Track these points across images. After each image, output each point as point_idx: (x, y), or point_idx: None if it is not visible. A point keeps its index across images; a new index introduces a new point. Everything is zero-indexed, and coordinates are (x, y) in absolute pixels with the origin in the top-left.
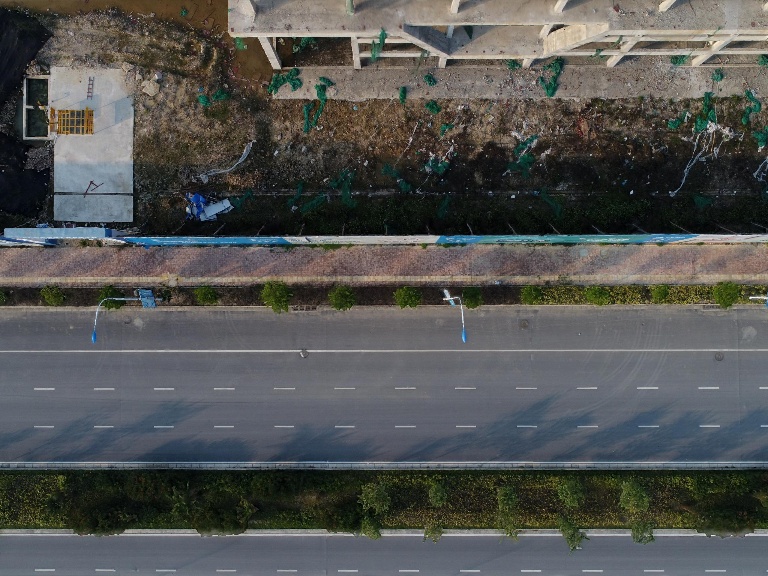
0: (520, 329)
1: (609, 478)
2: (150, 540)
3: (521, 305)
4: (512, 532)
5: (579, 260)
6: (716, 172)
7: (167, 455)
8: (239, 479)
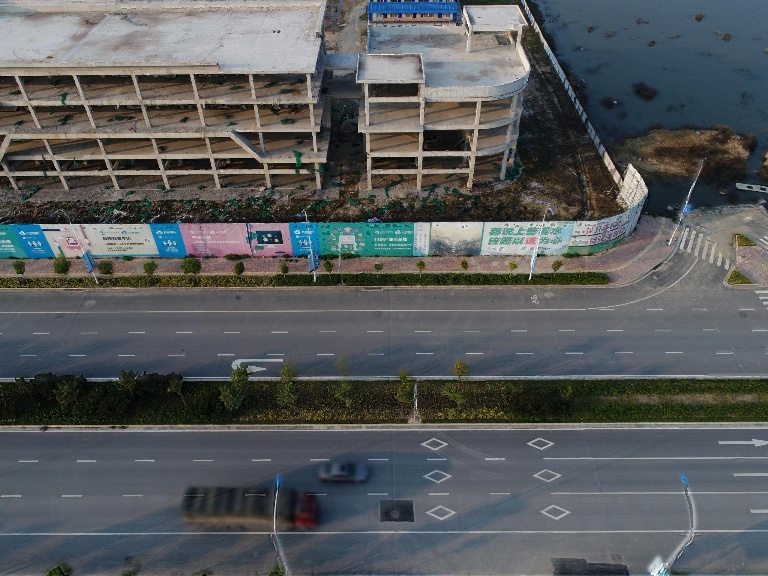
0: None
1: None
2: None
3: None
4: None
5: None
6: None
7: None
8: None
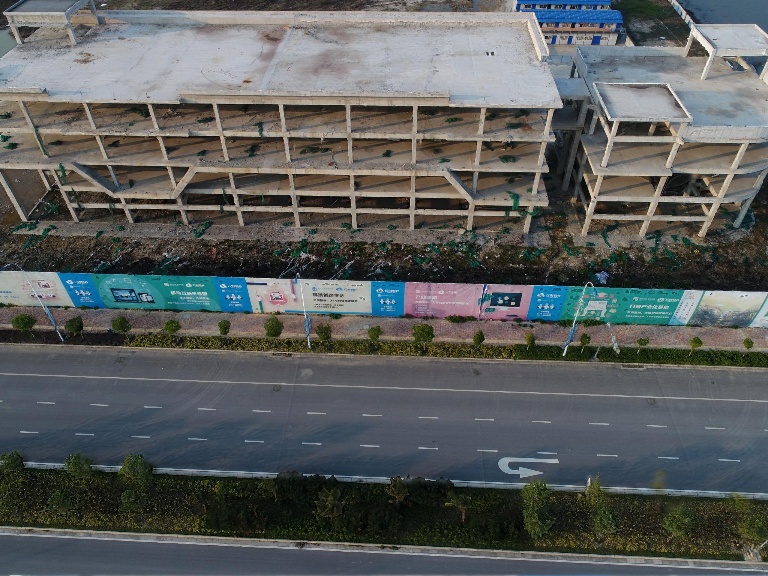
0: (115, 363)
1: None
2: None
3: (124, 348)
4: (2, 497)
5: (181, 321)
6: (302, 278)
7: None
8: None
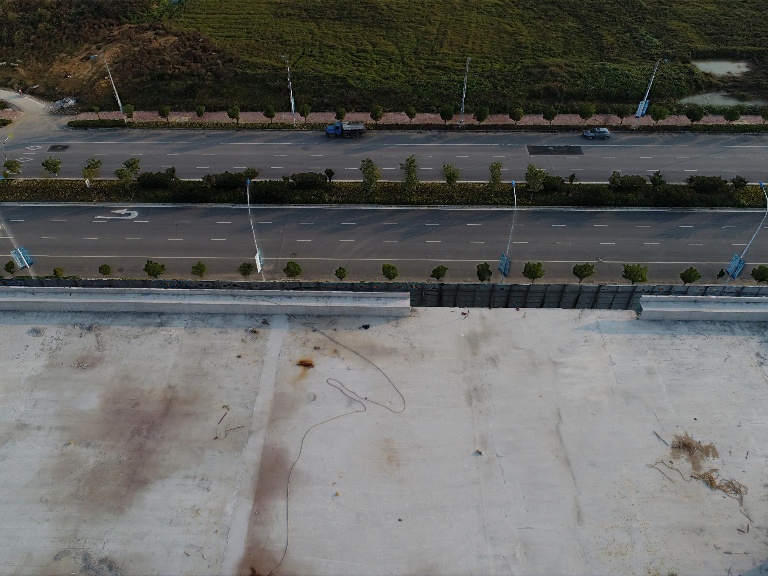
0: None
1: (378, 200)
2: (669, 181)
3: None
4: None
5: None
6: None
7: (677, 214)
8: (623, 202)
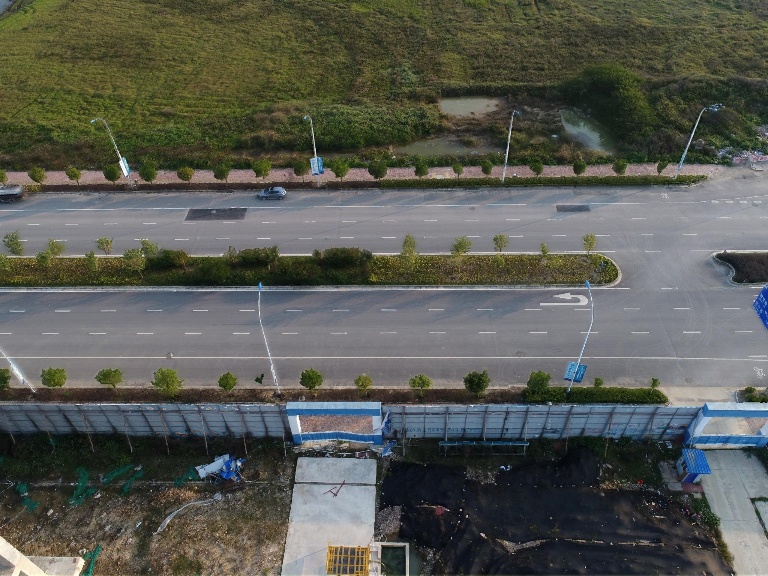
0: None
1: None
2: None
3: None
4: None
5: None
6: None
7: (294, 294)
8: (241, 280)
